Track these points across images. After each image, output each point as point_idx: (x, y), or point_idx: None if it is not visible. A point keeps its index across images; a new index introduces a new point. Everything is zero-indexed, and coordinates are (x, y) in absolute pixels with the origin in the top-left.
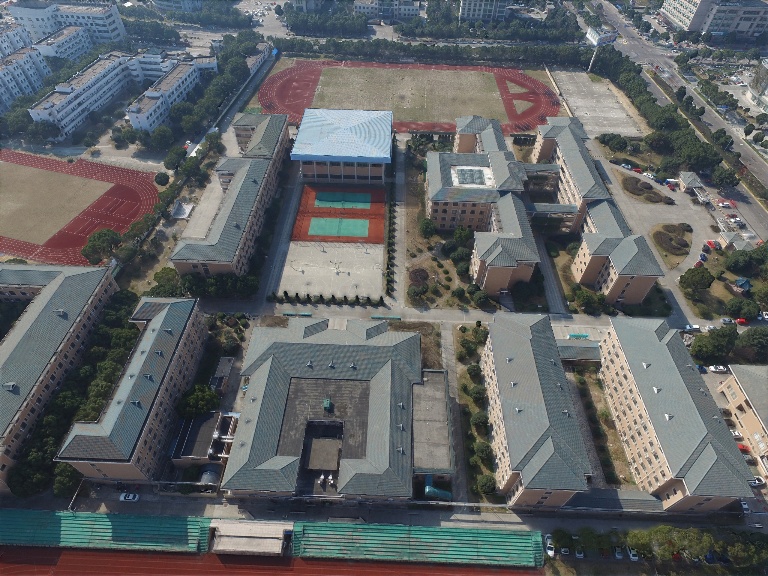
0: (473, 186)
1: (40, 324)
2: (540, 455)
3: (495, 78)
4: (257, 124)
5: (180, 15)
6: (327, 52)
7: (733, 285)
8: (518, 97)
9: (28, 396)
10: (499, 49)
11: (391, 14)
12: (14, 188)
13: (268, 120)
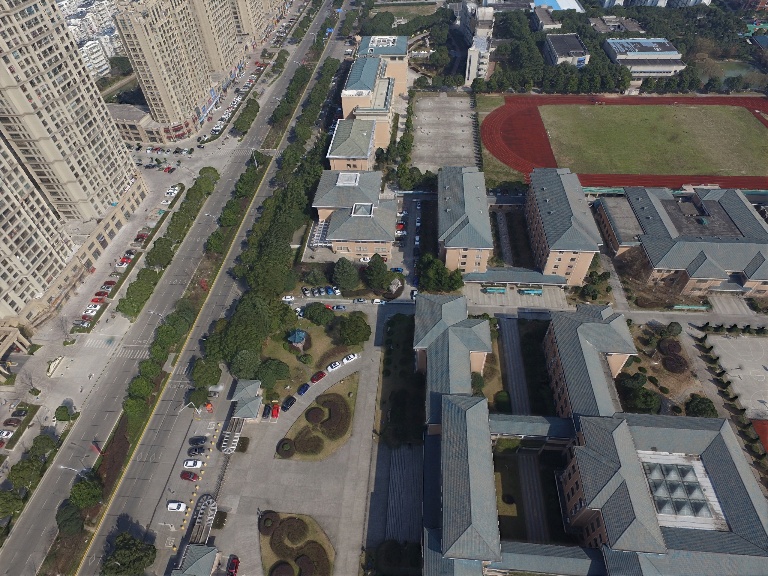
0: (664, 458)
1: None
2: (563, 172)
3: None
4: None
5: None
6: None
7: (300, 347)
8: None
9: None
10: None
11: None
12: None
13: None
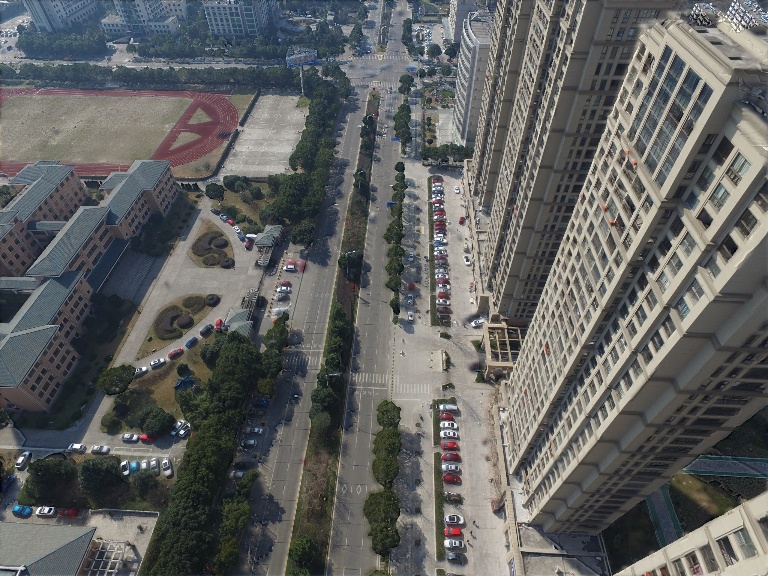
0: None
1: None
2: None
3: (189, 105)
4: None
5: None
6: (33, 78)
7: None
8: (190, 129)
9: None
10: (205, 72)
11: (139, 32)
12: None
13: None
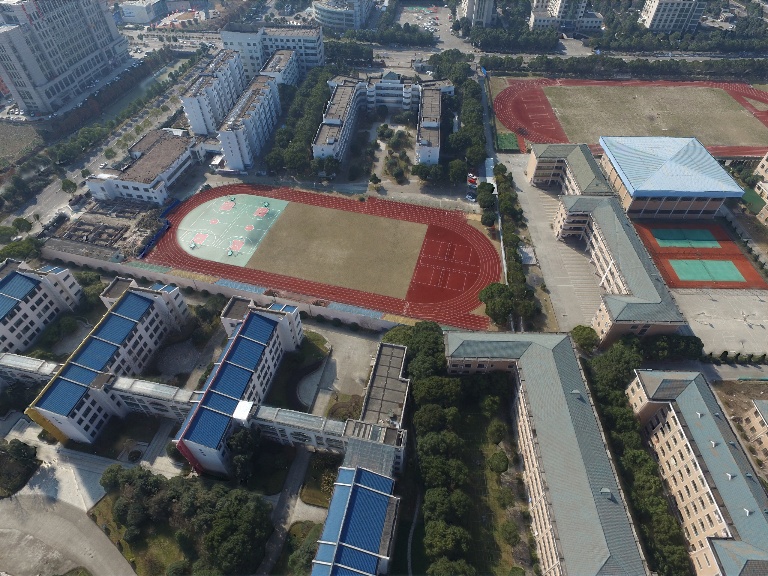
0: None
1: (574, 411)
2: None
3: (729, 94)
4: (565, 156)
5: (362, 34)
6: (534, 70)
7: None
8: None
9: (624, 504)
10: (724, 63)
11: (575, 27)
12: (326, 232)
13: (580, 151)
